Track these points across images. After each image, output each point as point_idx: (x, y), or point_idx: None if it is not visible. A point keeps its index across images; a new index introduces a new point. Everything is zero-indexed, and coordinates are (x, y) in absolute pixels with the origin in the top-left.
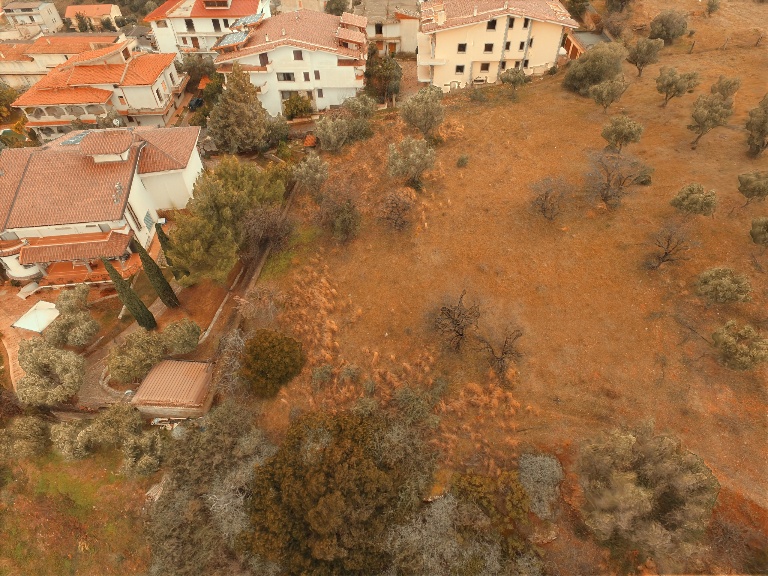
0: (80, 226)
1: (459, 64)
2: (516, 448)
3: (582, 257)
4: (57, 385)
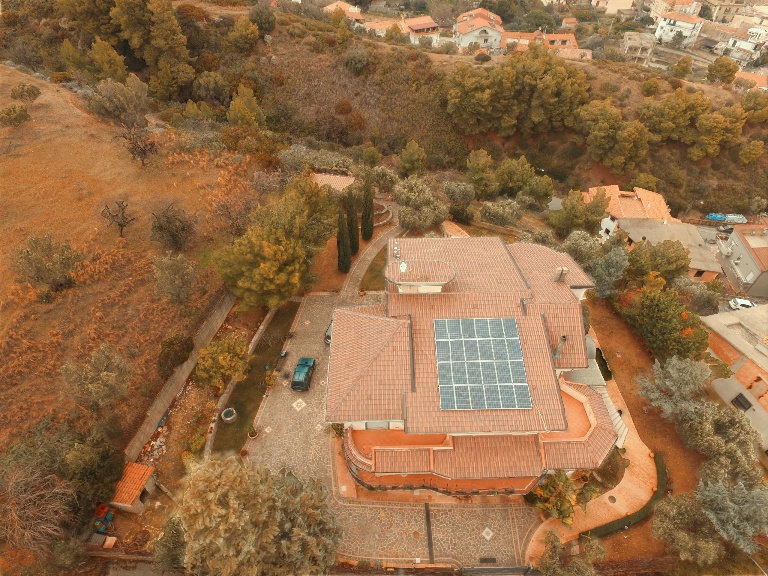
0: None
1: None
2: None
3: (6, 187)
4: None
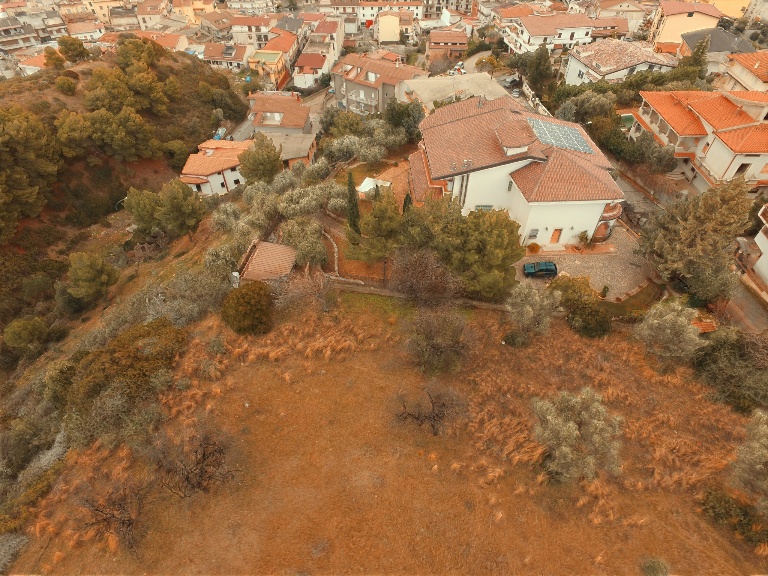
0: None
1: None
2: None
3: None
4: None
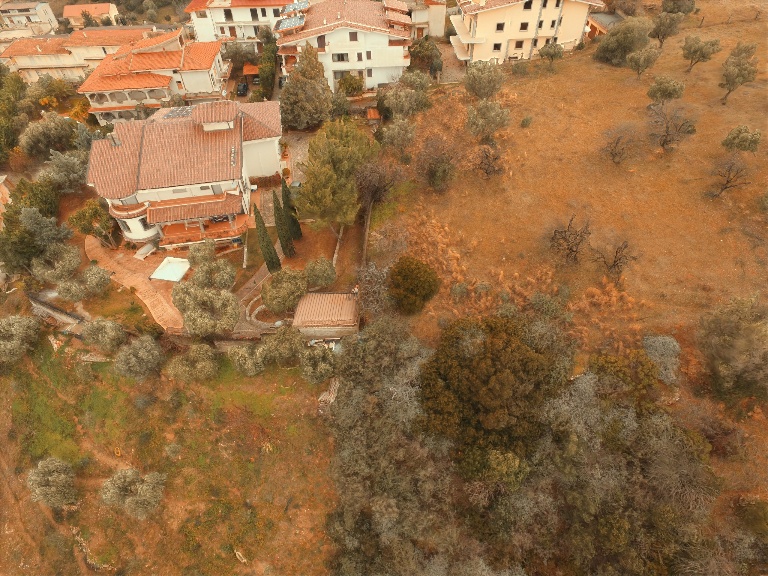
0: (196, 189)
1: (497, 42)
2: (638, 332)
3: (653, 191)
4: None
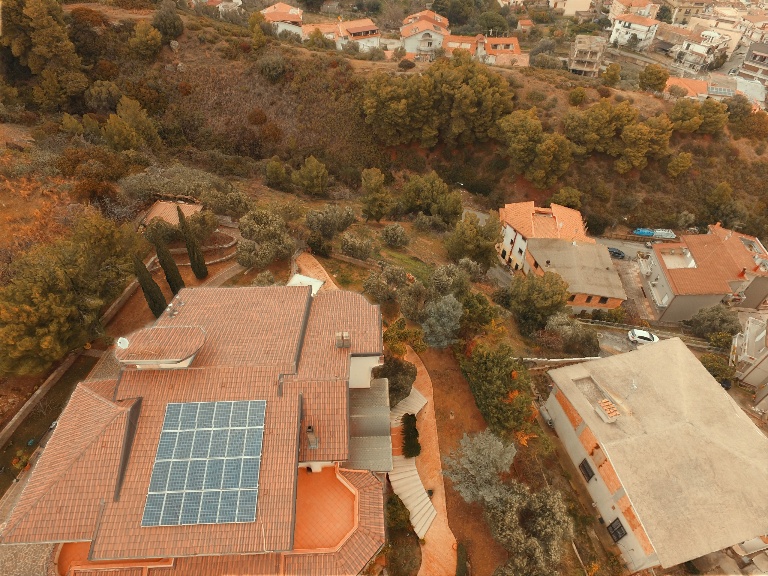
0: None
1: None
2: None
3: None
4: None
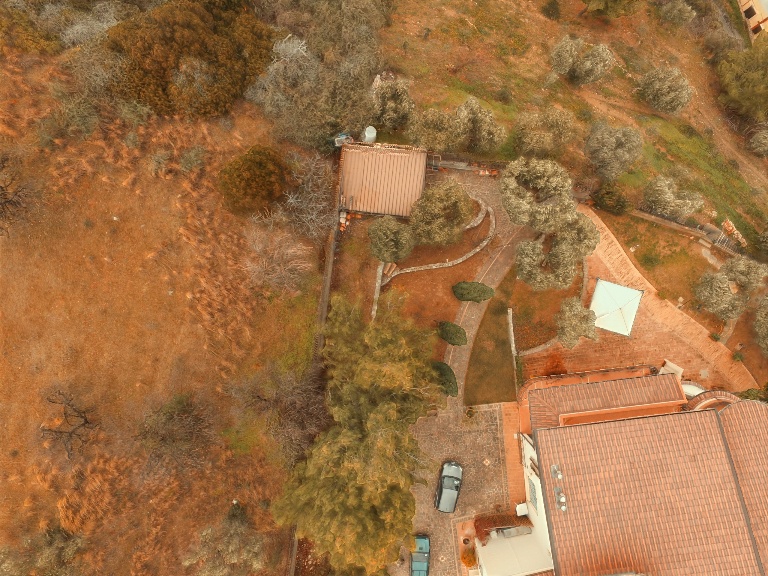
0: None
1: None
2: None
3: None
4: (529, 189)
